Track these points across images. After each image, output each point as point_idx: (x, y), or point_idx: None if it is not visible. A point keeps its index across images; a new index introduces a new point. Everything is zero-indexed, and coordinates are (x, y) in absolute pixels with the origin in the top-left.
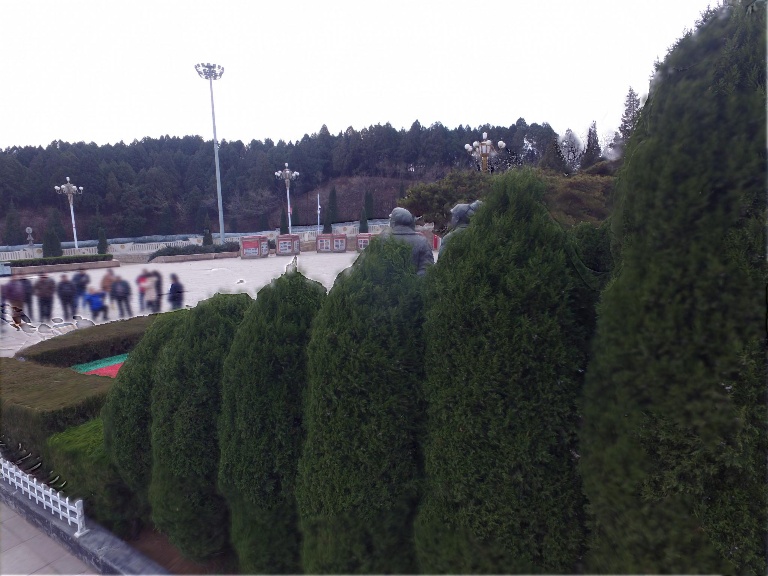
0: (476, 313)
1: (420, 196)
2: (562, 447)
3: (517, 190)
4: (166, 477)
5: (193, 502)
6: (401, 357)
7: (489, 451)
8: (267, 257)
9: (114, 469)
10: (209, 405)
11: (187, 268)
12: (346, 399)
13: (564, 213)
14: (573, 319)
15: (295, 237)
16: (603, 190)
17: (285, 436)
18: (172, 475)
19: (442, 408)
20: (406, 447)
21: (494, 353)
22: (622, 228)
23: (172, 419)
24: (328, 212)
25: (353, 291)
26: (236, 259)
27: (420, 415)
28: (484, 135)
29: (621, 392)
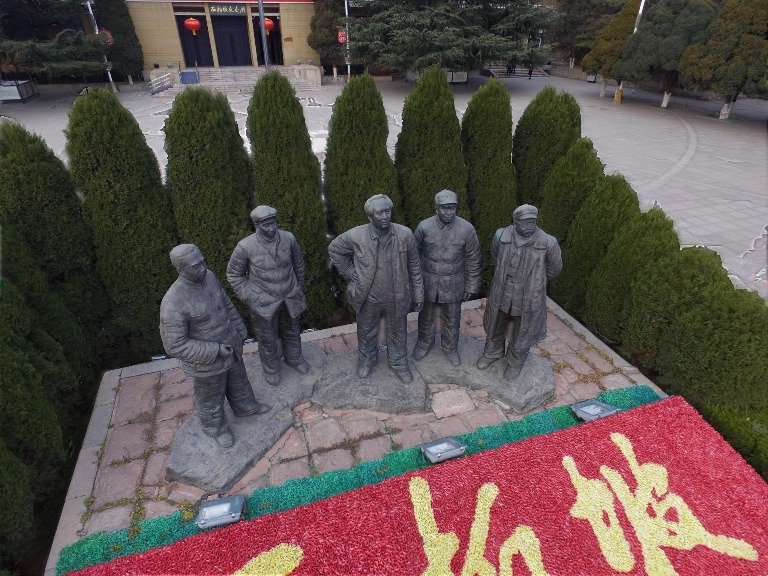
0: None
1: None
2: None
3: None
4: None
5: None
6: None
7: None
8: None
9: None
10: None
11: None
12: None
13: None
14: None
15: None
16: None
17: None
18: None
19: None
20: None
21: None
22: None
23: None
24: None
25: None
26: None
27: None
28: None
29: None
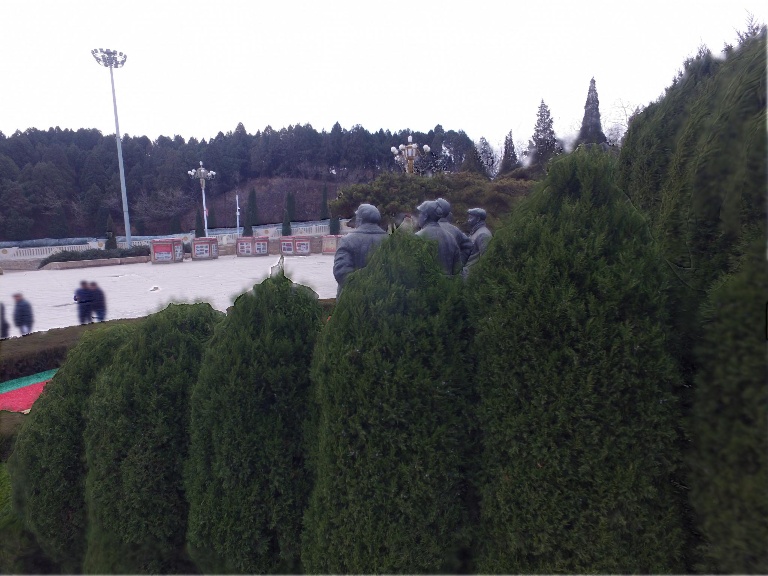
0: (559, 321)
1: (352, 197)
2: (663, 478)
3: (593, 172)
4: (111, 545)
5: (151, 574)
6: (448, 377)
7: (579, 490)
8: (182, 262)
9: (29, 537)
10: (171, 447)
11: (88, 275)
12: (378, 434)
13: (492, 215)
14: (670, 324)
15: (213, 240)
16: (526, 194)
17: (283, 482)
18: (120, 542)
19: (511, 439)
20: (454, 488)
21: (587, 370)
22: (740, 215)
23: (119, 469)
24: (248, 214)
25: (380, 297)
26: (146, 264)
27: (471, 447)
28: (409, 138)
29: (758, 412)
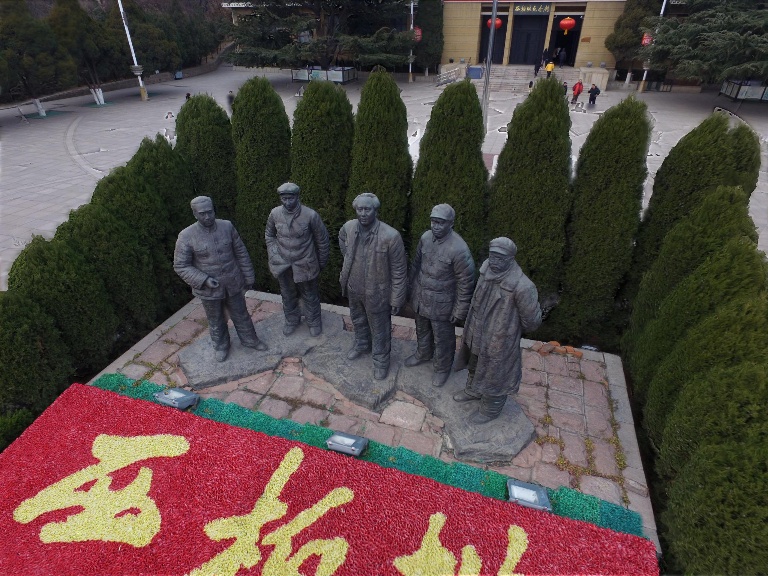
0: None
1: None
2: None
3: None
4: None
5: None
6: None
7: None
8: None
9: None
10: None
11: None
12: None
13: None
14: None
15: None
16: None
17: None
18: None
19: None
20: None
21: None
22: None
23: None
24: None
25: None
26: None
27: None
28: None
29: None
